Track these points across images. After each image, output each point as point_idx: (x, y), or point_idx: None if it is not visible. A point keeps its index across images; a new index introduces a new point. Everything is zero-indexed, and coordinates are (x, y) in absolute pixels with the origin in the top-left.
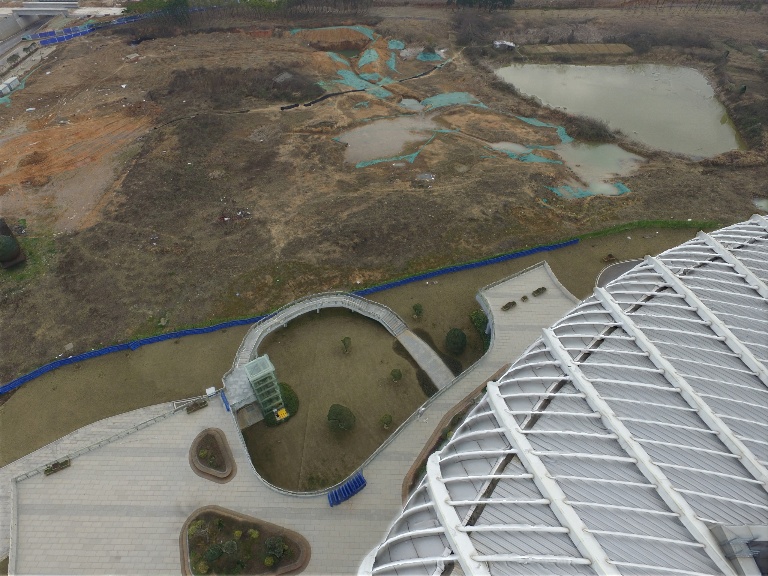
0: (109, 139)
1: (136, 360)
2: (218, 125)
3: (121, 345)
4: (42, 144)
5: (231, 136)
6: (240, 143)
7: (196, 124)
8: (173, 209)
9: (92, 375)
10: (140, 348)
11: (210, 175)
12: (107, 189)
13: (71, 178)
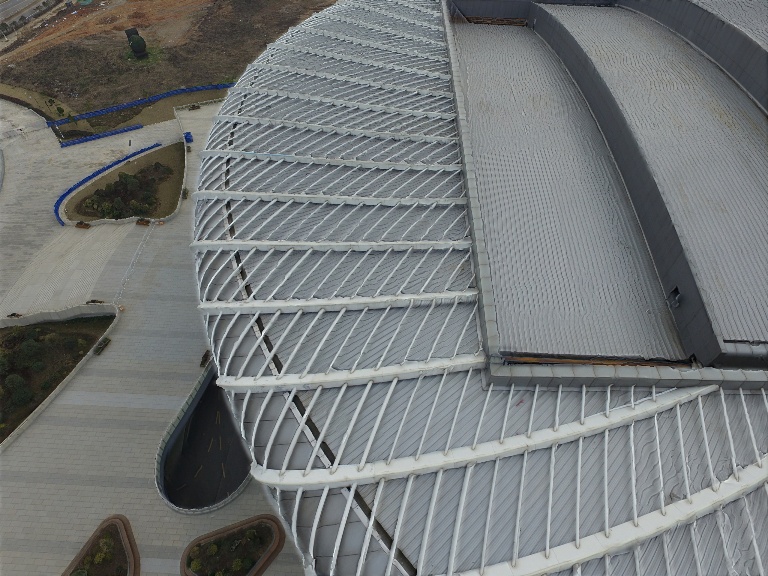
0: (184, 8)
1: (222, 93)
2: (258, 3)
3: (213, 85)
4: (140, 9)
5: (267, 10)
6: (273, 13)
7: (243, 1)
8: (233, 39)
9: (198, 97)
10: (223, 89)
11: (255, 26)
12: (189, 30)
13: (164, 25)
